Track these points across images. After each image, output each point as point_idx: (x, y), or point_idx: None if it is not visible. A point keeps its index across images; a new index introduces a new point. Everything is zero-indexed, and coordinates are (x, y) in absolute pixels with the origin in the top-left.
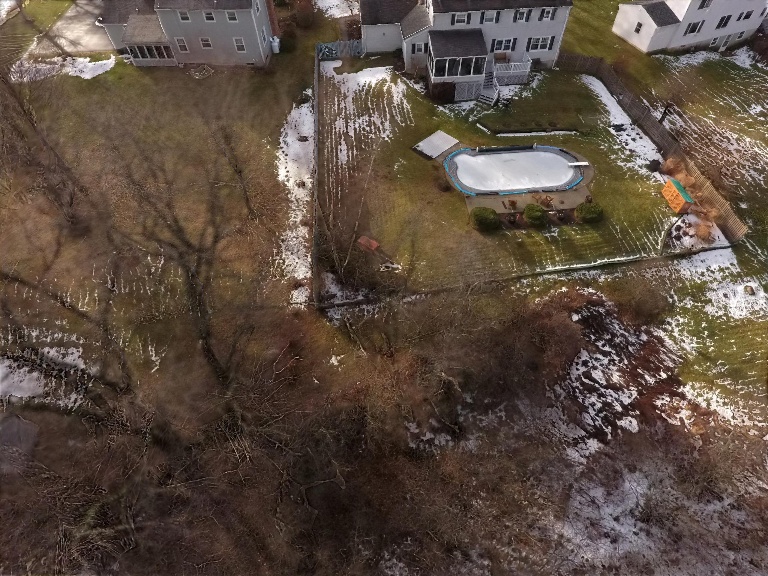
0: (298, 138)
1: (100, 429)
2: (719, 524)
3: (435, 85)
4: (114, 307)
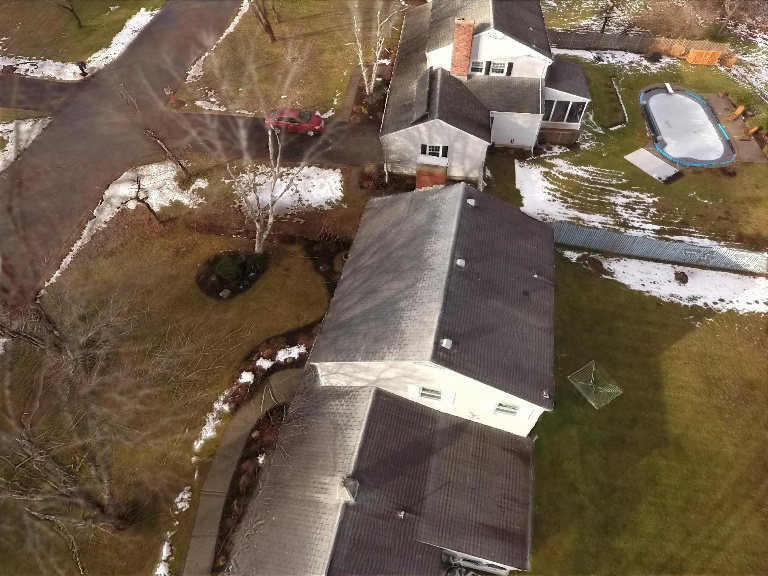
0: (681, 283)
1: None
2: None
3: (578, 130)
4: None
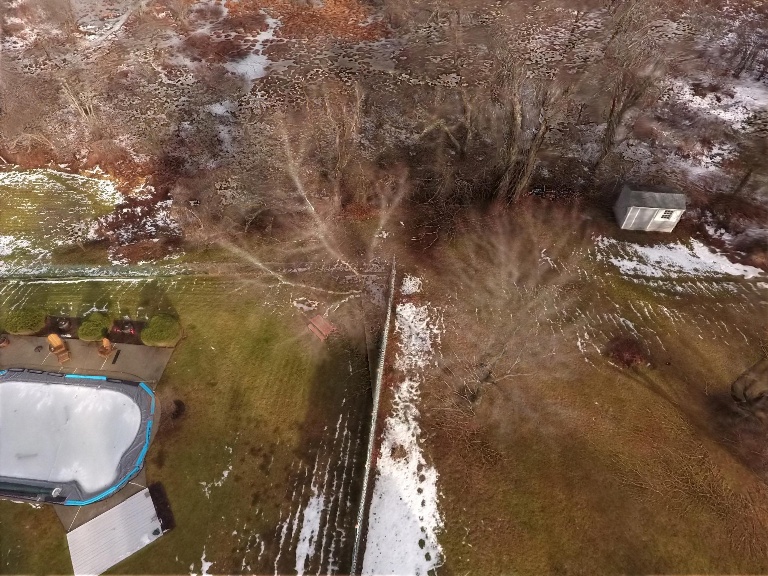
0: None
1: (571, 221)
2: (179, 149)
3: None
4: (610, 300)
